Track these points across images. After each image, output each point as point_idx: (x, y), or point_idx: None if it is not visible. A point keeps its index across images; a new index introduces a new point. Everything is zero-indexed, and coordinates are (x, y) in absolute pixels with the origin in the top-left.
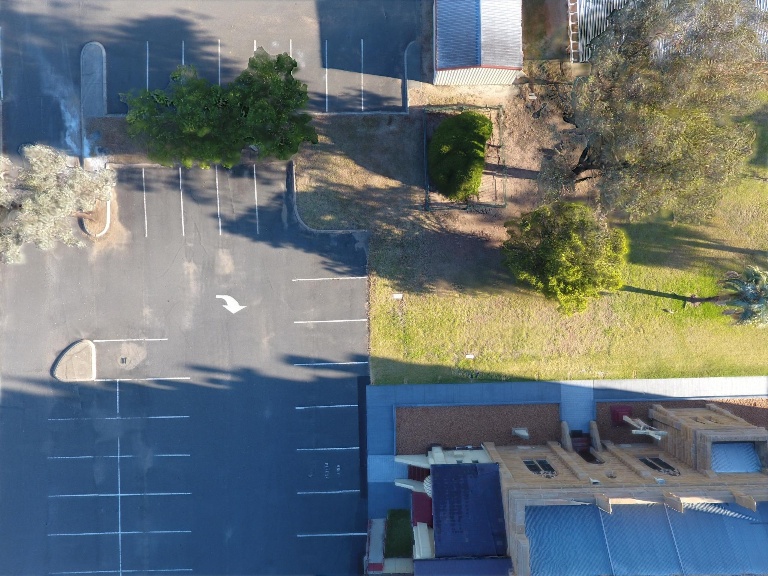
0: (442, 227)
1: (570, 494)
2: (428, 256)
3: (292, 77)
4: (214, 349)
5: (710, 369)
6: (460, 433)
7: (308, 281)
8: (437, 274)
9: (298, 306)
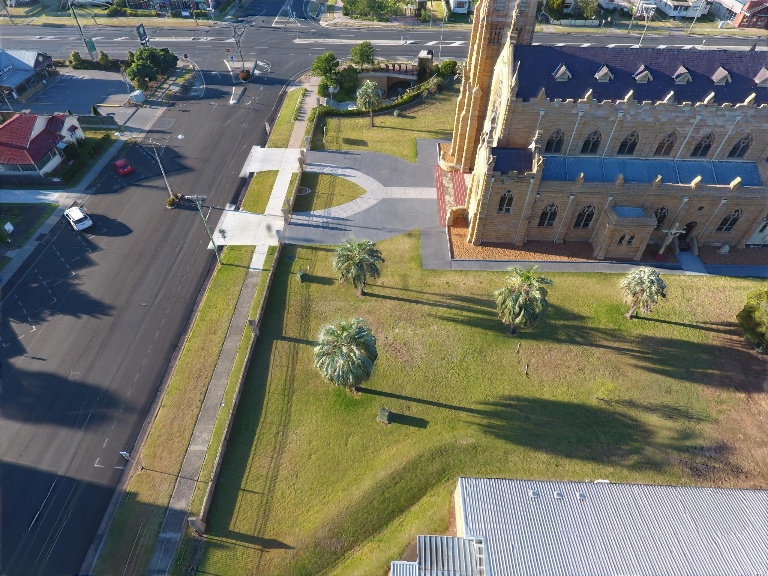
0: None
1: (749, 191)
2: None
3: None
4: None
5: (605, 277)
6: (762, 254)
7: None
8: None
9: None
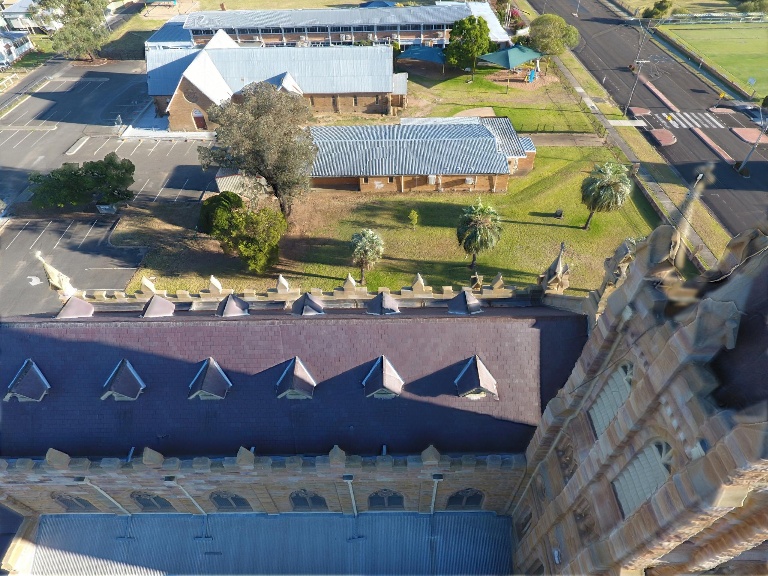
0: (200, 248)
1: None
2: (184, 260)
3: (130, 172)
4: (4, 304)
5: None
6: None
7: (96, 270)
8: (186, 268)
9: (80, 282)
